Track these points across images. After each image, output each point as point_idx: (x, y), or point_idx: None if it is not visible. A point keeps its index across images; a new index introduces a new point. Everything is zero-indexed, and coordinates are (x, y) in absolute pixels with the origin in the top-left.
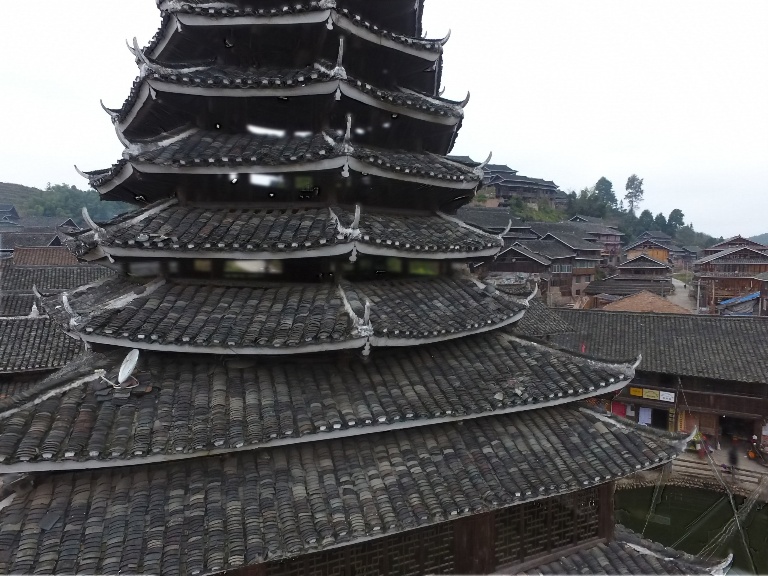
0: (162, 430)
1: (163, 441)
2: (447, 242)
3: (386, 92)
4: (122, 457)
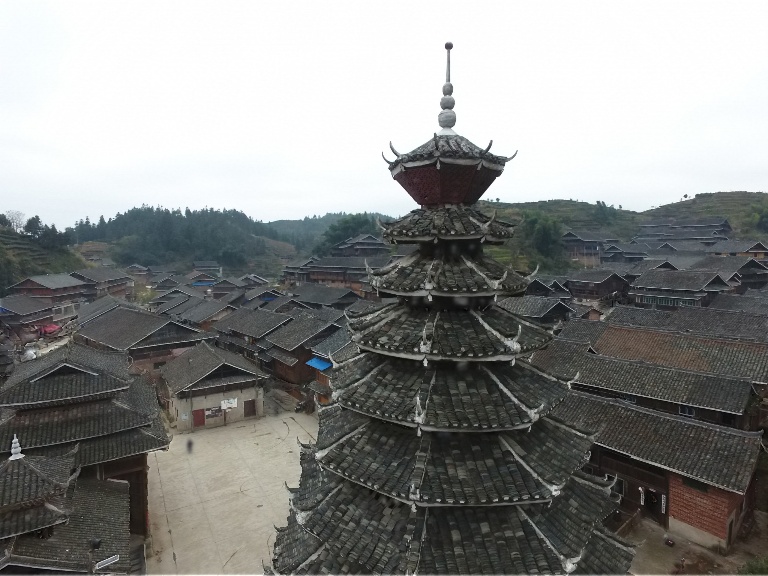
0: None
1: None
2: None
3: (371, 520)
4: None
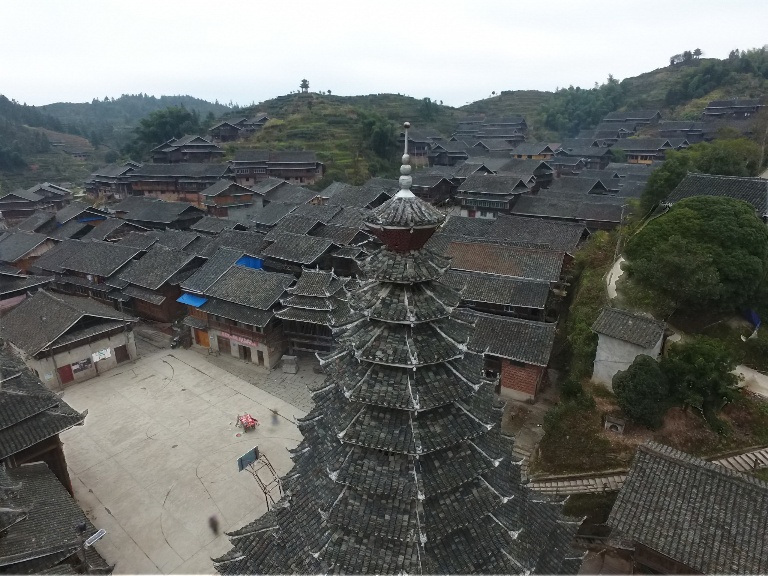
0: (274, 567)
1: (271, 573)
2: (382, 569)
3: (382, 466)
4: (261, 570)
